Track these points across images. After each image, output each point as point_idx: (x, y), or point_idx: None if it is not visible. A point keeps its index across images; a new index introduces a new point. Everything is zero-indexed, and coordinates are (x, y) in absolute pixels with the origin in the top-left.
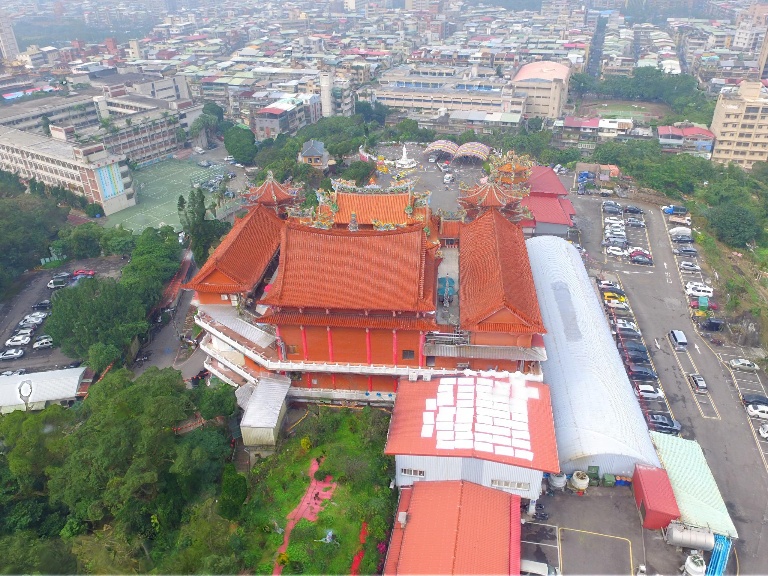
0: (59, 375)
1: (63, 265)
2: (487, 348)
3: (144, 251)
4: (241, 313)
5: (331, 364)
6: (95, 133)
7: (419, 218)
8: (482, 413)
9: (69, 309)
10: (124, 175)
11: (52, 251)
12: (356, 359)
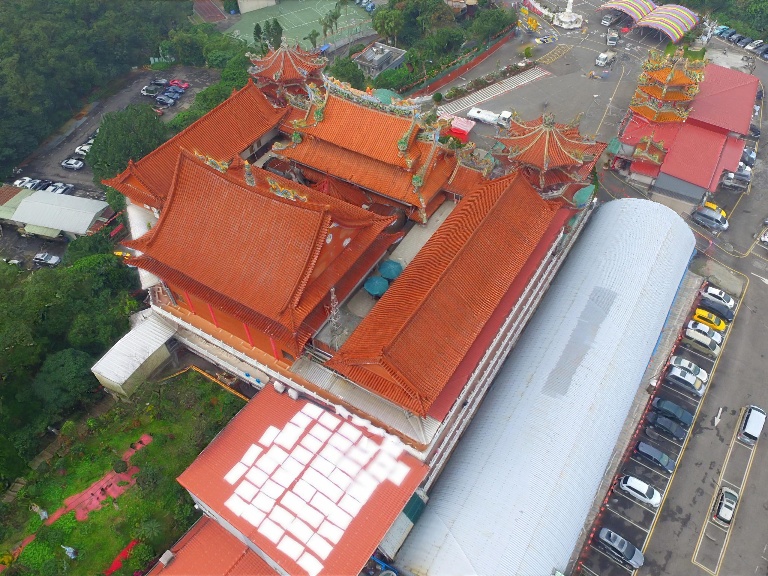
0: (83, 206)
1: (169, 68)
2: (367, 392)
3: (228, 76)
4: None
5: (207, 332)
6: None
7: None
8: (308, 479)
9: (105, 139)
10: None
11: (160, 51)
12: (239, 335)
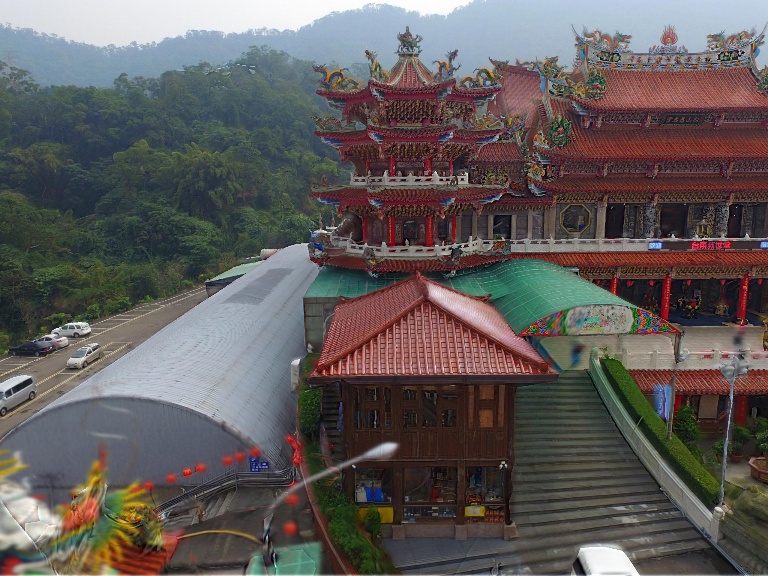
0: None
1: None
2: None
3: None
4: None
5: None
6: None
7: None
8: None
9: None
10: None
11: None
12: None
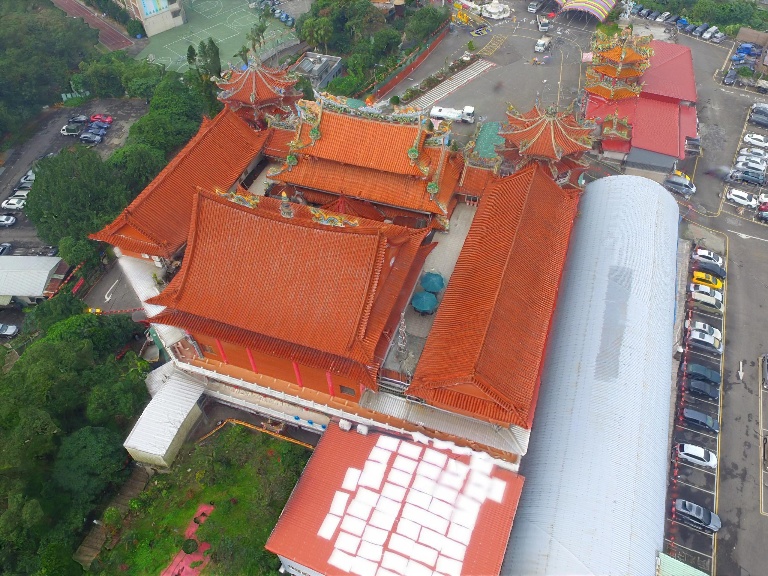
0: (31, 265)
1: (85, 103)
2: (448, 413)
3: (159, 104)
4: (160, 282)
5: (249, 381)
6: None
7: (423, 169)
8: (409, 516)
9: (44, 188)
10: None
11: (72, 86)
12: (284, 377)
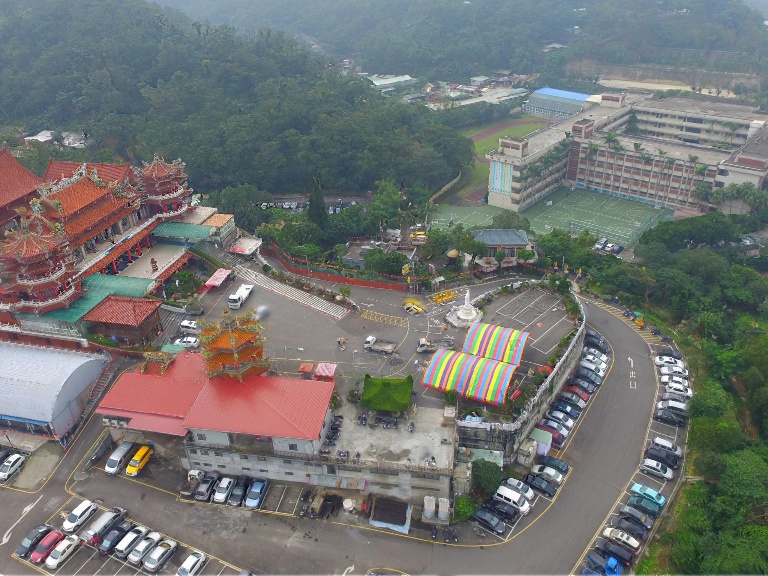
0: None
1: None
2: None
3: None
4: None
5: None
6: (600, 142)
7: (22, 210)
8: None
9: None
10: (518, 180)
11: None
12: None
